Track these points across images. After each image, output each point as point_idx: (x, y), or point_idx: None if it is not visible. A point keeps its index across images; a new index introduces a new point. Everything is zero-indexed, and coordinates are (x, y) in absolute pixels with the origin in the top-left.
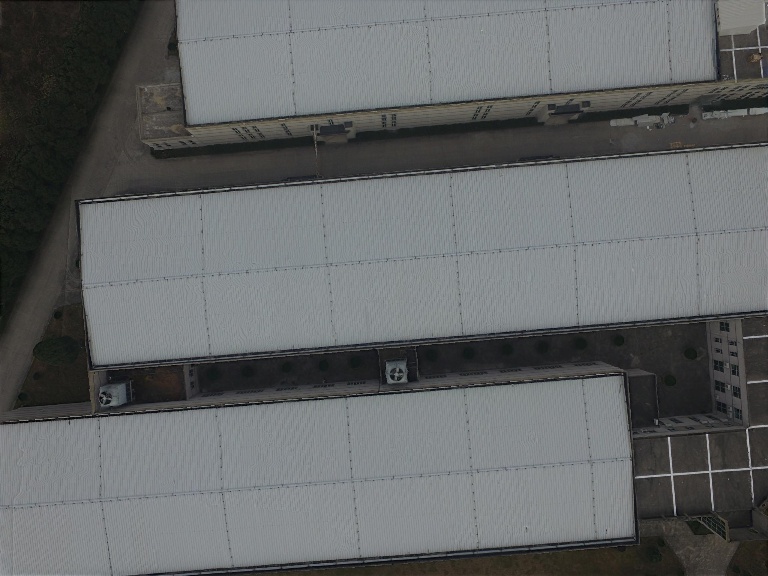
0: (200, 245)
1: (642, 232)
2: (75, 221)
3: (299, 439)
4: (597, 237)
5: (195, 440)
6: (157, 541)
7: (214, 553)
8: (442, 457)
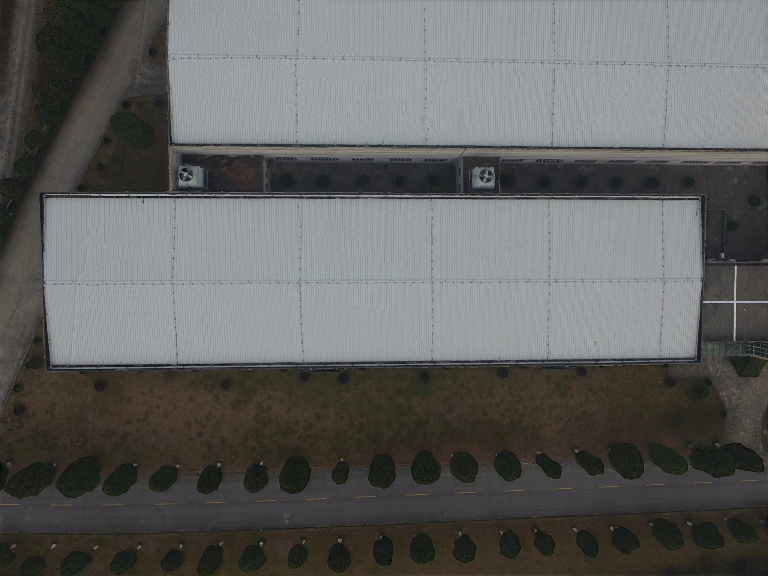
0: (296, 26)
1: (733, 59)
2: (151, 8)
3: (381, 236)
4: (691, 59)
5: (275, 229)
6: (228, 330)
7: (285, 346)
8: (522, 264)
